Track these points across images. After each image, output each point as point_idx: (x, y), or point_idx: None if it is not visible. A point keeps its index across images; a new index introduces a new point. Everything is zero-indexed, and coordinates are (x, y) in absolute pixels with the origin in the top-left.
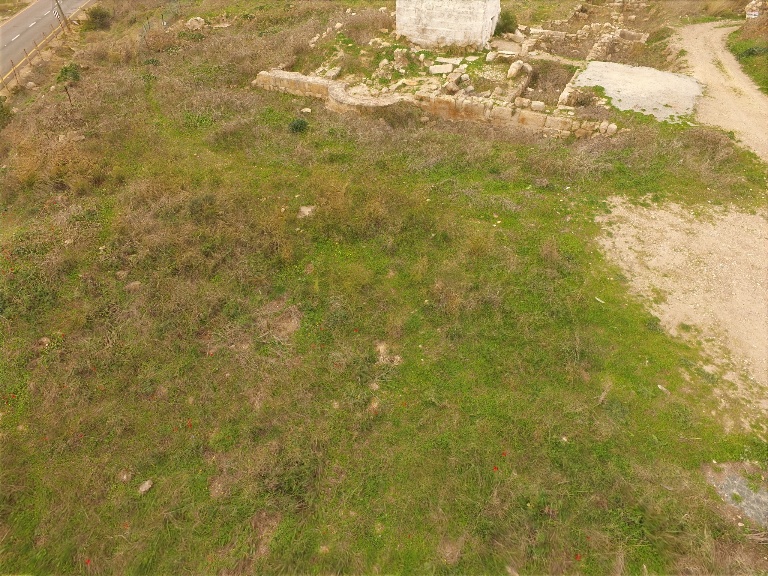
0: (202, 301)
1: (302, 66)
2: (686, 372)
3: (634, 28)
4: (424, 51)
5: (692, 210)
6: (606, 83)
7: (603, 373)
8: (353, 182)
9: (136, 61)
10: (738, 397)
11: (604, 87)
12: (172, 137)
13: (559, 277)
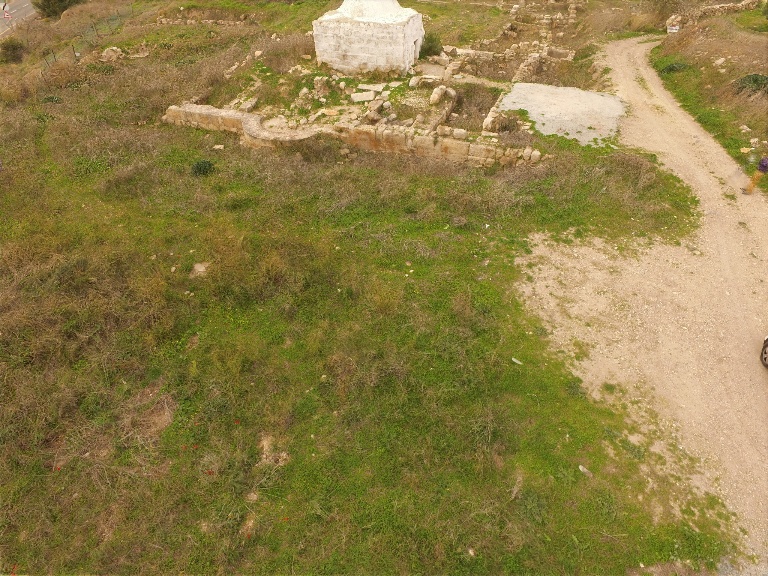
0: (54, 398)
1: (218, 98)
2: (610, 446)
3: (562, 45)
4: (345, 78)
5: (616, 244)
6: (530, 106)
7: (518, 455)
8: (257, 231)
9: (34, 99)
10: (666, 474)
11: (528, 110)
12: (60, 186)
13: (473, 336)
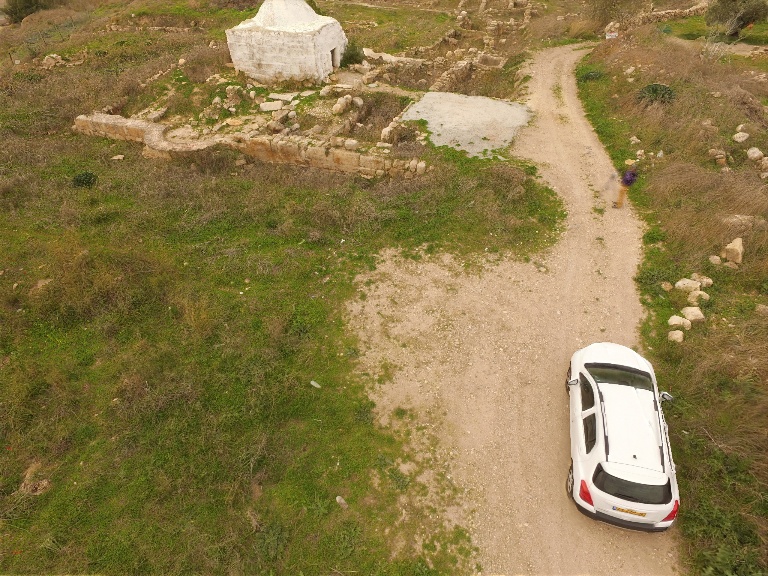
0: None
1: (133, 107)
2: (377, 475)
3: (502, 52)
4: (256, 87)
5: (464, 261)
6: (433, 116)
7: (279, 485)
8: (114, 245)
9: None
10: (423, 505)
11: (428, 121)
12: None
13: (278, 358)
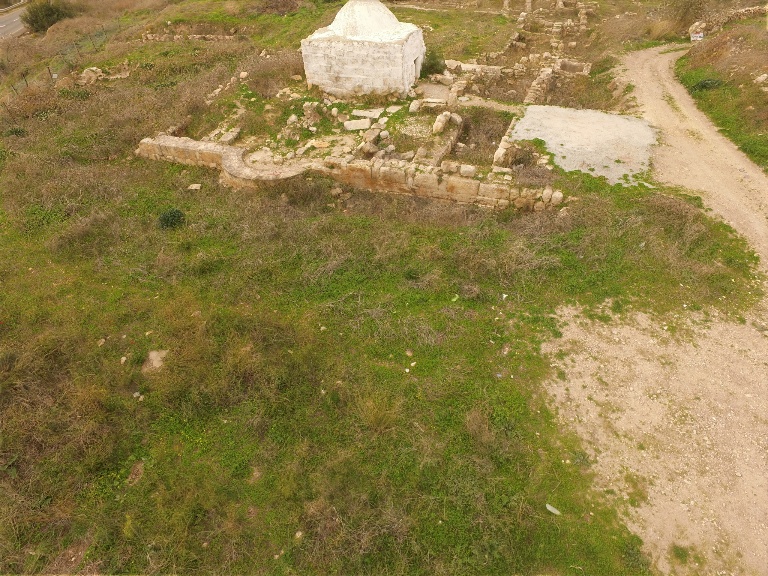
0: None
1: (198, 127)
2: None
3: (575, 56)
4: (337, 104)
5: (665, 322)
6: (547, 134)
7: None
8: (228, 303)
9: None
10: None
11: (545, 140)
12: (7, 243)
13: (493, 470)
